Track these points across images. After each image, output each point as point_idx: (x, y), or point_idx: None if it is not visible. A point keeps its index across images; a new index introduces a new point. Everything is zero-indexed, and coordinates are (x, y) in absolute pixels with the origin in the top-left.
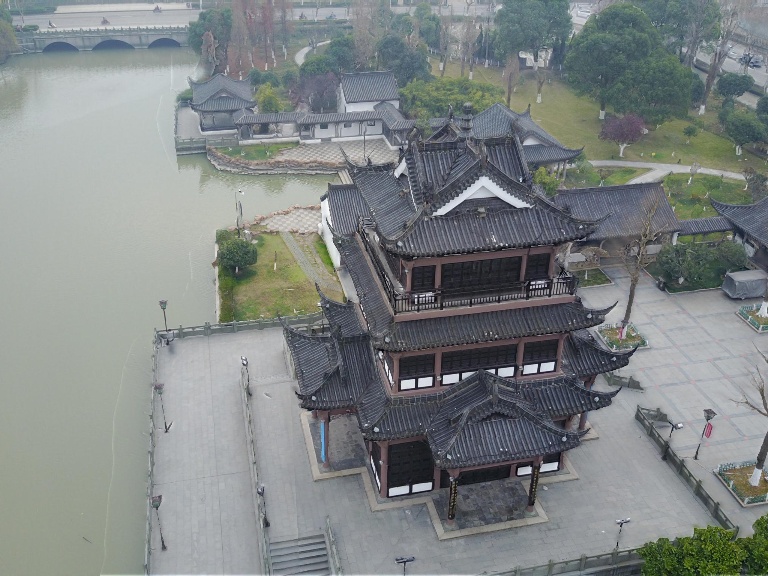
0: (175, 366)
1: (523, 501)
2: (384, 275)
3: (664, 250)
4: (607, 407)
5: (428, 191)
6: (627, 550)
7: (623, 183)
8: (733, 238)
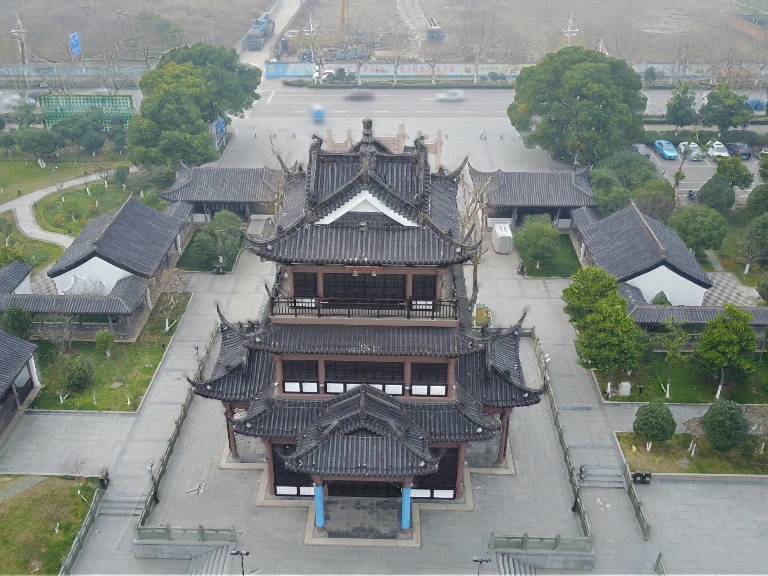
0: None
1: None
2: (410, 304)
3: (203, 242)
4: None
5: (421, 202)
6: None
7: (18, 232)
8: (190, 215)
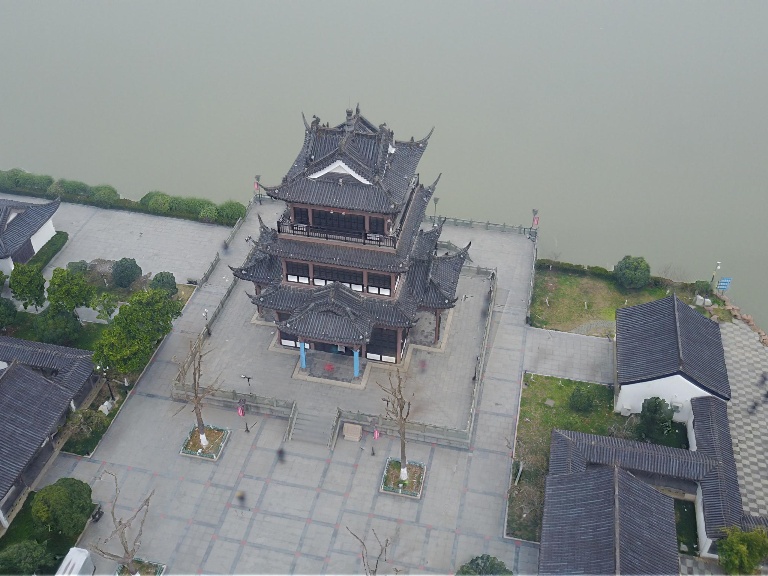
0: (501, 238)
1: (270, 318)
2: None
3: None
4: (318, 400)
5: None
6: (203, 330)
7: None
8: None
